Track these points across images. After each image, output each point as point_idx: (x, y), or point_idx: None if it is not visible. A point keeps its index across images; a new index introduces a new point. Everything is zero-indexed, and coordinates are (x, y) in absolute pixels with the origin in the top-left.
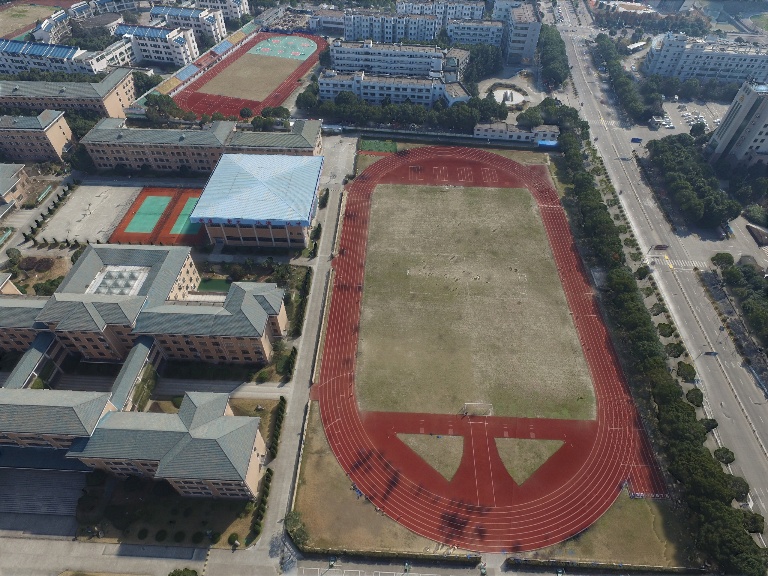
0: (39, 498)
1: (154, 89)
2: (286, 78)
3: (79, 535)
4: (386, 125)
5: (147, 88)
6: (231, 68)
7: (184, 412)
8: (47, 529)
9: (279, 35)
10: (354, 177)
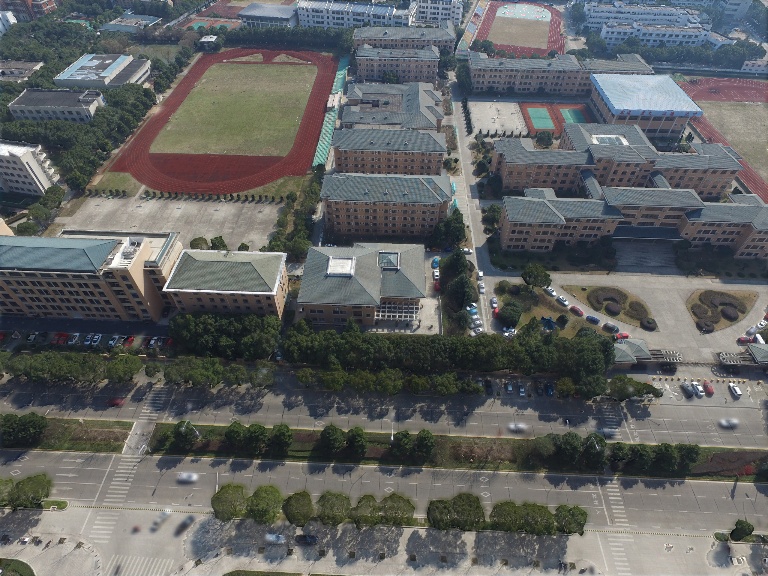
0: (647, 258)
1: (462, 39)
2: (548, 33)
3: (688, 275)
4: (667, 63)
5: (458, 37)
6: (496, 26)
7: (743, 201)
8: (665, 272)
9: (509, 3)
10: None
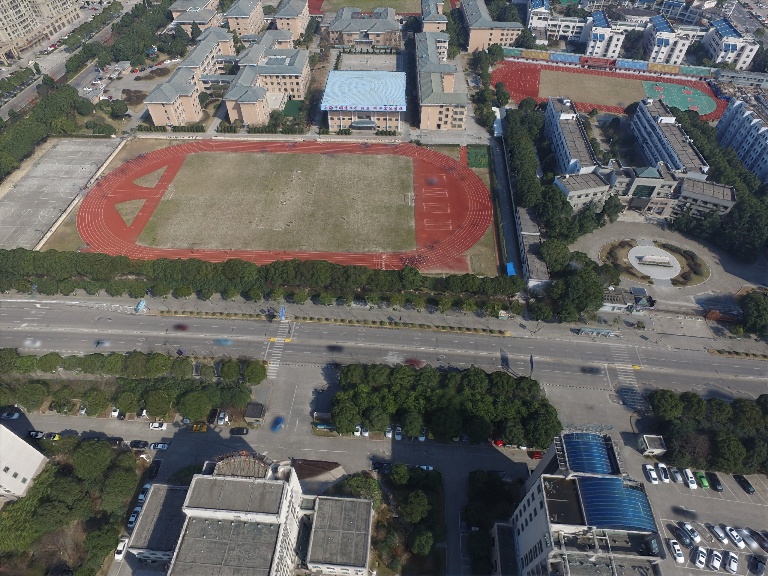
0: None
1: (522, 50)
2: (596, 104)
3: None
4: None
5: None
6: (599, 77)
7: None
8: None
9: (707, 92)
10: (420, 145)
